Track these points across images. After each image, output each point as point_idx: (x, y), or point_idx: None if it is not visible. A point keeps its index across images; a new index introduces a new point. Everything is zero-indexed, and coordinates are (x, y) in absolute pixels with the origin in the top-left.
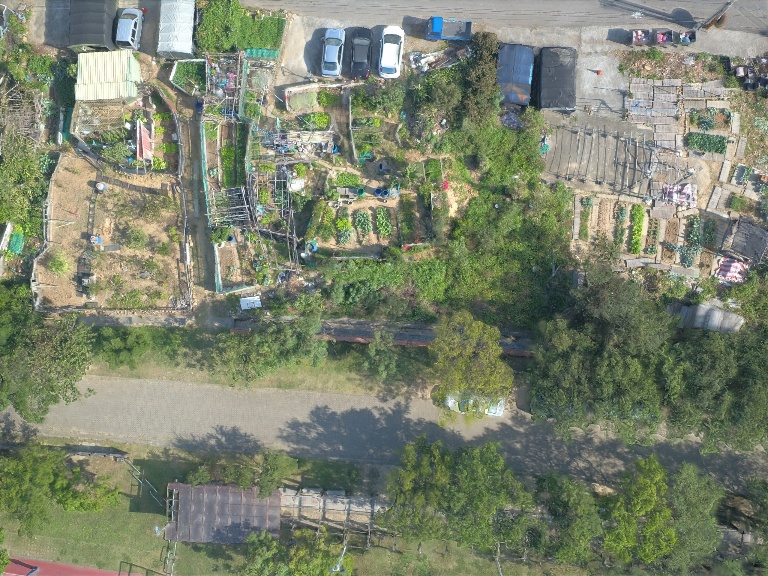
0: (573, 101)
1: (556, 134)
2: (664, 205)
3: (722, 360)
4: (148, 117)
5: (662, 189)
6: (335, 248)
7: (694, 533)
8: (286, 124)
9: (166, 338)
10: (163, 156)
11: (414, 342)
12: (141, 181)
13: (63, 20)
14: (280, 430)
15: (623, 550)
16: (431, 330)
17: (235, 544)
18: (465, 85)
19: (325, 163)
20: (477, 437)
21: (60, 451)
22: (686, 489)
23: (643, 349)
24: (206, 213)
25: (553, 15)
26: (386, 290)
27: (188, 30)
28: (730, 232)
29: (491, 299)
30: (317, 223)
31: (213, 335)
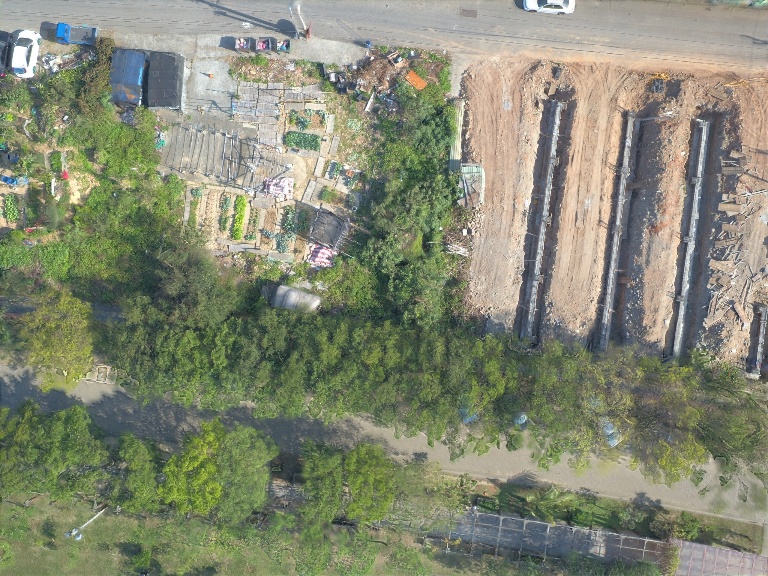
0: (176, 101)
1: (172, 131)
2: (264, 196)
3: (270, 334)
4: None
5: (263, 182)
6: None
7: (235, 487)
8: None
9: None
10: None
11: None
12: None
13: None
14: None
15: (181, 502)
16: None
17: None
18: None
19: None
20: (95, 403)
21: None
22: (233, 448)
23: (199, 323)
24: None
25: (173, 23)
26: (15, 269)
27: None
28: None
29: (107, 279)
30: None
31: None
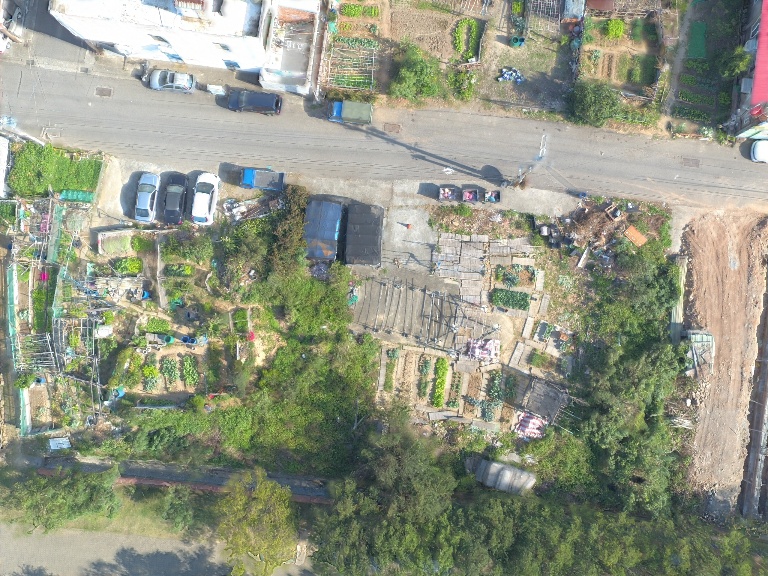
0: (377, 258)
1: (365, 285)
2: (468, 359)
3: (499, 530)
4: None
5: (466, 343)
6: (143, 393)
7: None
8: (98, 267)
9: None
10: None
11: (219, 488)
12: None
13: None
14: (86, 571)
15: None
16: (240, 473)
17: None
18: (274, 236)
19: (137, 307)
20: None
21: None
22: None
23: (421, 518)
24: (11, 358)
25: (366, 167)
26: (193, 436)
27: (0, 173)
28: (530, 388)
29: (295, 448)
30: (121, 371)
31: (23, 473)
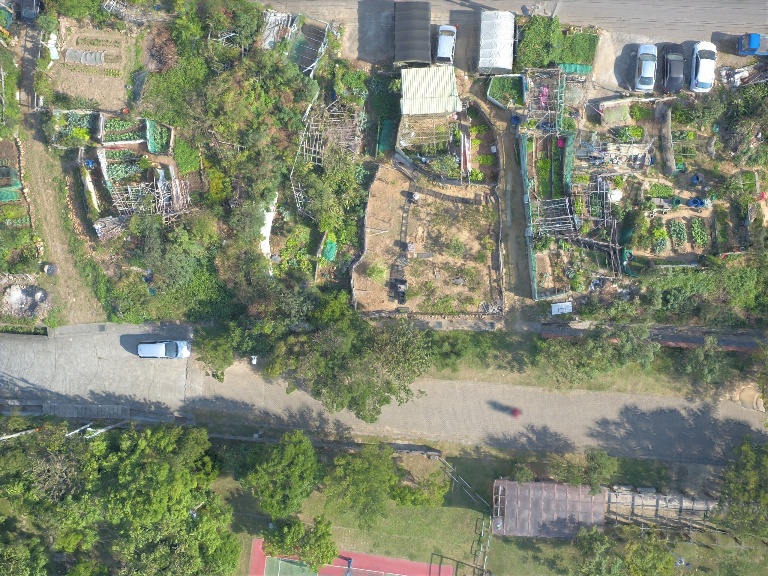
0: None
1: None
2: None
3: None
4: (463, 130)
5: None
6: (649, 256)
7: None
8: (600, 137)
9: (477, 342)
10: (478, 167)
11: (724, 346)
12: (455, 191)
13: (376, 36)
14: (590, 430)
15: None
16: (735, 335)
17: (545, 538)
18: None
19: (637, 174)
20: None
21: (390, 449)
22: None
23: None
24: (530, 223)
25: None
26: (698, 296)
27: (509, 46)
28: None
29: None
30: (638, 232)
31: (523, 339)
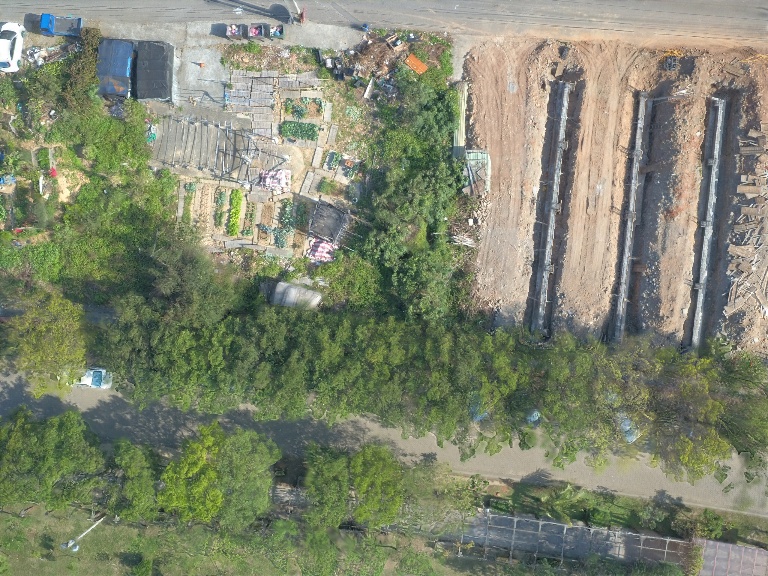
0: (166, 92)
1: (163, 123)
2: (261, 190)
3: (269, 333)
4: None
5: (259, 174)
6: None
7: (237, 494)
8: None
9: None
10: None
11: None
12: None
13: None
14: None
15: (181, 510)
16: None
17: None
18: None
19: None
20: (91, 409)
21: None
22: (233, 453)
23: (194, 323)
24: None
25: (161, 11)
26: (5, 271)
27: None
28: None
29: (100, 279)
30: None
31: None
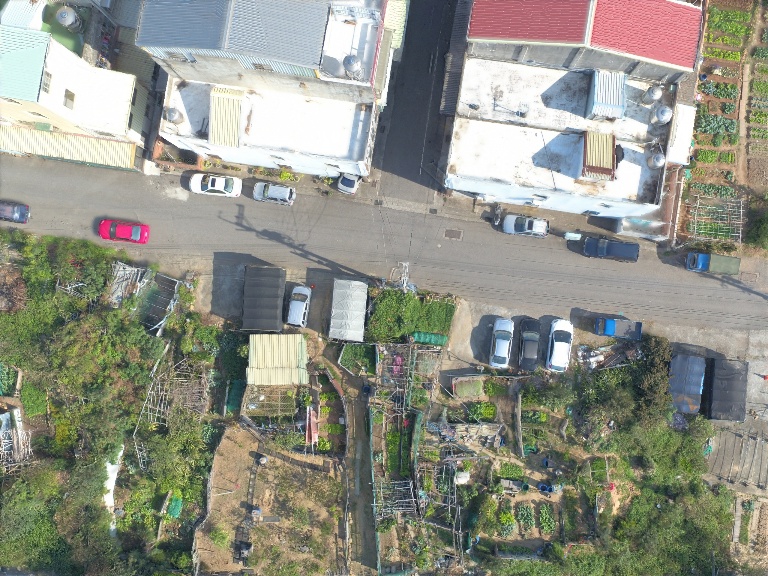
0: (743, 414)
1: (720, 436)
2: None
3: None
4: (314, 395)
5: None
6: (496, 539)
7: None
8: (452, 412)
9: None
10: (327, 435)
11: None
12: (303, 456)
13: (230, 290)
14: None
15: None
16: None
17: None
18: (634, 387)
19: (489, 452)
20: None
21: None
22: None
23: None
24: (373, 503)
25: (722, 316)
26: None
27: (360, 318)
28: None
29: None
30: (483, 520)
31: None
